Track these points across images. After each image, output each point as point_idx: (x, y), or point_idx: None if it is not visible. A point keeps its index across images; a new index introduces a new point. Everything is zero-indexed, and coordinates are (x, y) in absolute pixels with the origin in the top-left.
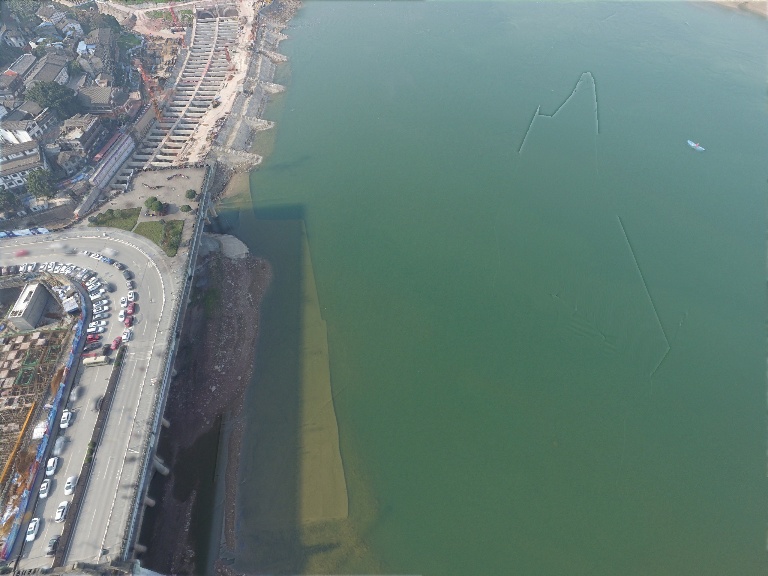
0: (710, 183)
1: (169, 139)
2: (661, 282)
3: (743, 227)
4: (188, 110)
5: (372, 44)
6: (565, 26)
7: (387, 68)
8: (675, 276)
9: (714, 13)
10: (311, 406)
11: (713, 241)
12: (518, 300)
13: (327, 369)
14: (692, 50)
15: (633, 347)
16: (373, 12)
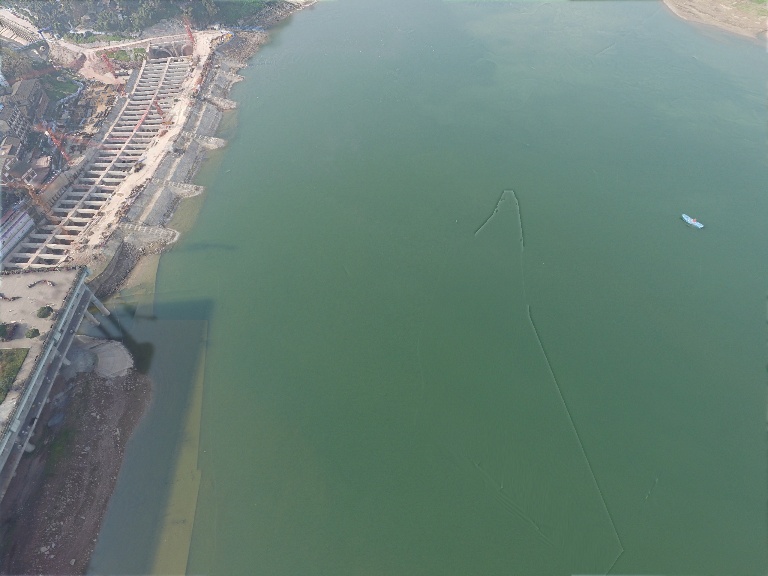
0: (703, 280)
1: (77, 212)
2: (630, 421)
3: (741, 344)
4: (108, 174)
5: (333, 86)
6: (554, 61)
7: (343, 117)
8: (650, 411)
9: (727, 44)
10: None
11: (702, 362)
12: (441, 451)
13: (186, 548)
14: (698, 92)
15: (575, 543)
16: (341, 47)
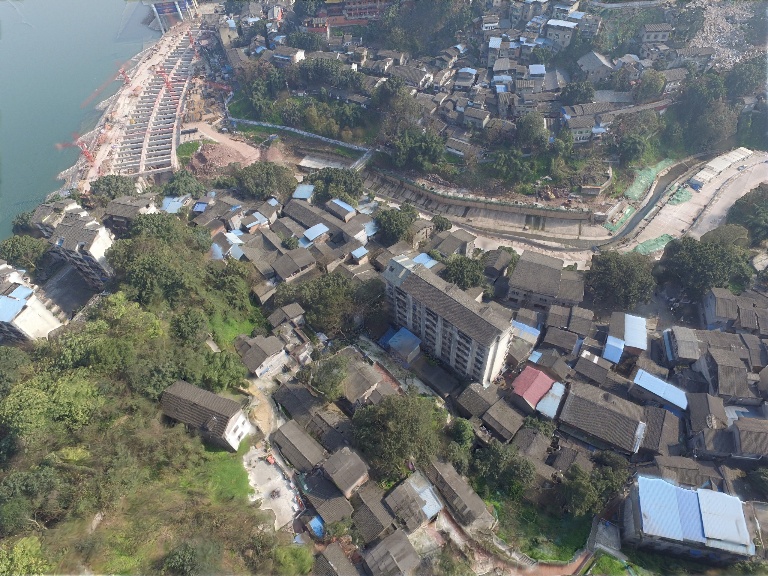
0: None
1: None
2: None
3: None
4: None
5: None
6: None
7: None
8: None
9: None
10: (134, 2)
11: None
12: None
13: None
14: None
15: (10, 7)
16: None
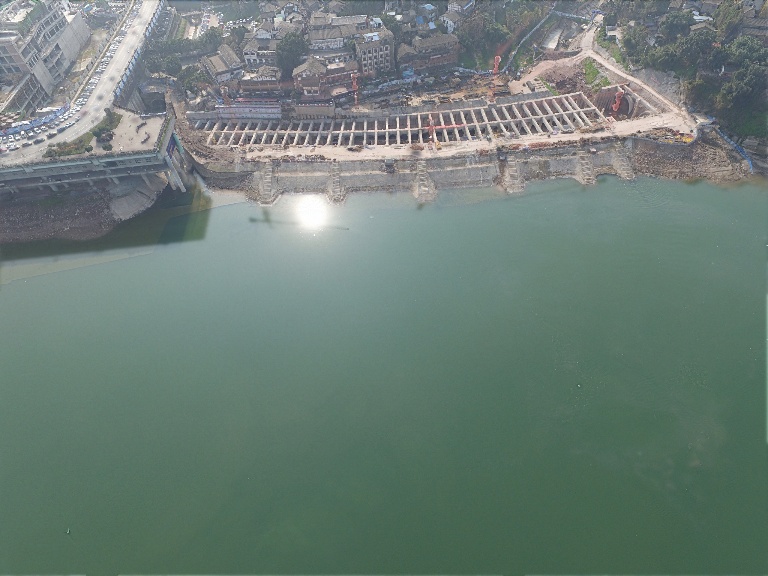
0: None
1: None
2: None
3: None
4: None
5: (600, 288)
6: None
7: (503, 312)
8: None
9: None
10: None
11: None
12: None
13: None
14: None
15: None
16: (751, 281)
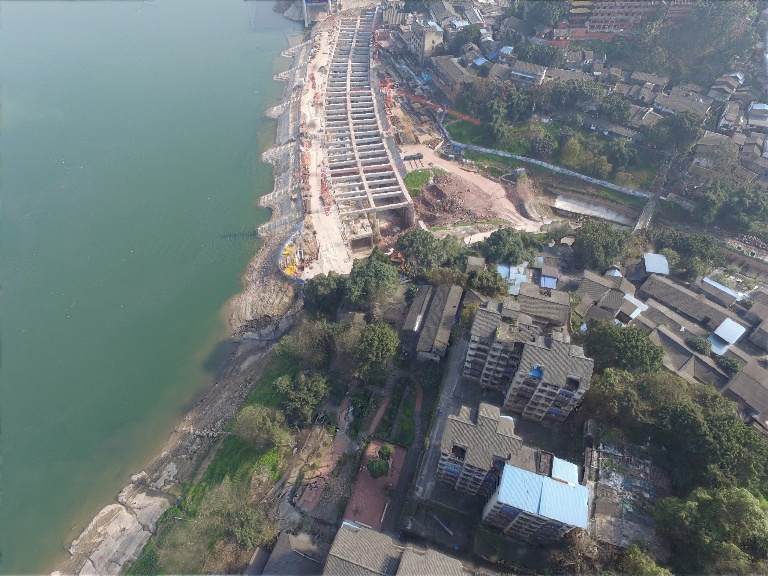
0: None
1: None
2: (71, 17)
3: None
4: None
5: (135, 187)
6: None
7: (137, 140)
8: (60, 21)
9: None
10: None
11: None
12: None
13: None
14: None
15: None
16: (89, 276)
